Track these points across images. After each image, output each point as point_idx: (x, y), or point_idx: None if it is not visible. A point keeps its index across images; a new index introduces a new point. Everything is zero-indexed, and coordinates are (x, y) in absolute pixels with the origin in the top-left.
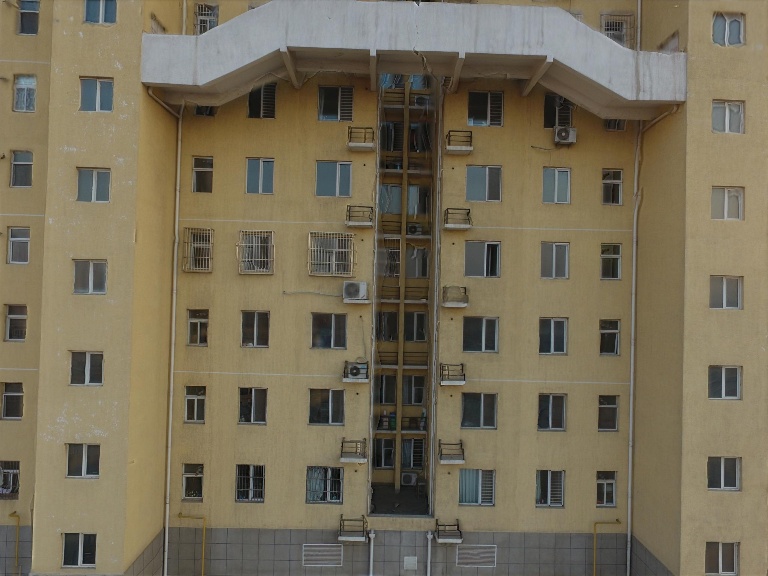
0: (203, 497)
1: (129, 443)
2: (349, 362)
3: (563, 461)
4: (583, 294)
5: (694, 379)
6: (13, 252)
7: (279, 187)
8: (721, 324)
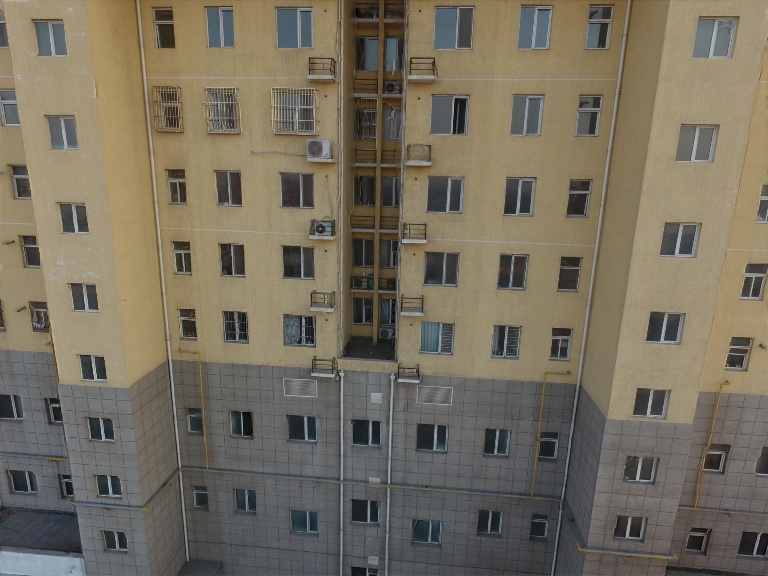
0: (197, 337)
1: (118, 284)
2: (315, 220)
3: (520, 318)
4: (554, 152)
5: (647, 236)
6: (6, 115)
7: (240, 39)
8: (685, 178)
